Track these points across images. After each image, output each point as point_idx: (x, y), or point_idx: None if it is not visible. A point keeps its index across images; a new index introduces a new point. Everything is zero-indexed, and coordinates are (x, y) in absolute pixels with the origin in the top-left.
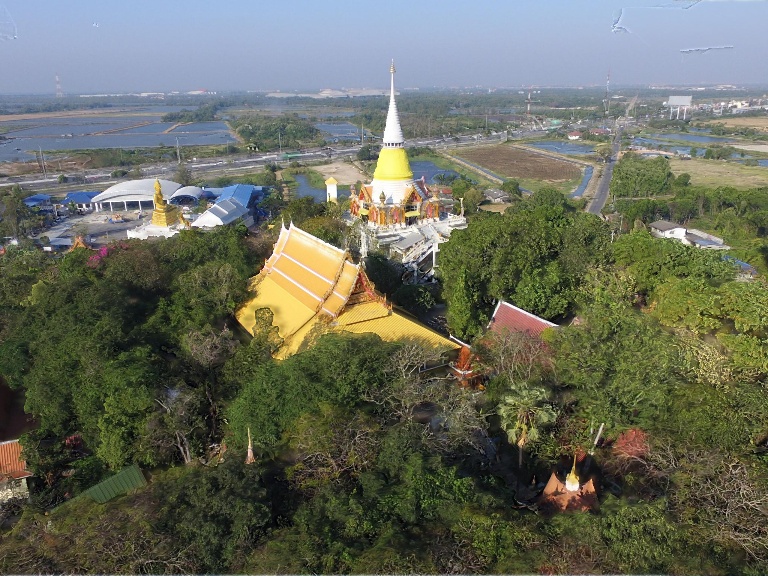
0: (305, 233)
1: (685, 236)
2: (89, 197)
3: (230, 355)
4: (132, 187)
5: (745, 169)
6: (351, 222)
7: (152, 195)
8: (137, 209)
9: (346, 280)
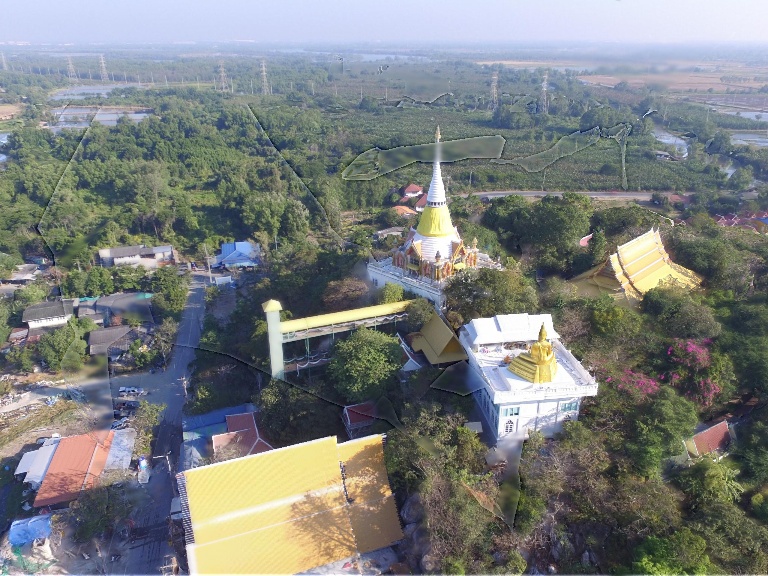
0: None
1: None
2: None
3: (732, 275)
4: None
5: None
6: None
7: None
8: None
9: None
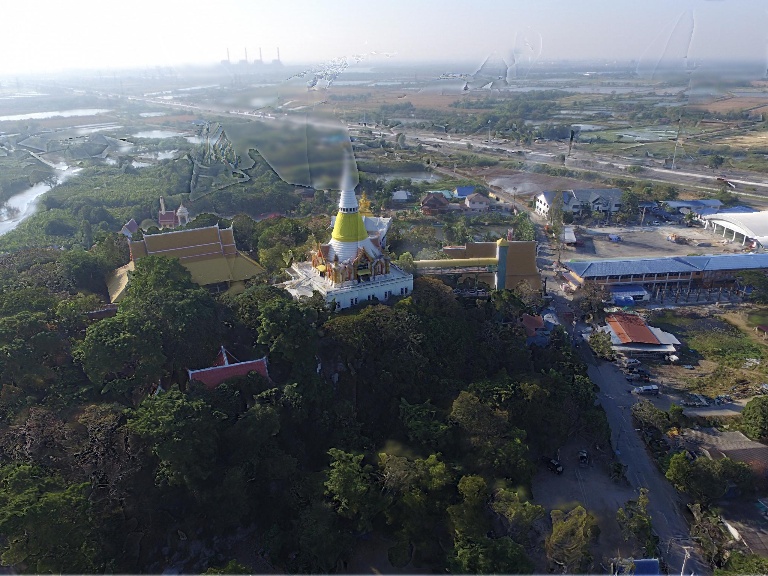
0: None
1: None
2: (715, 213)
3: None
4: (745, 215)
5: None
6: None
7: None
8: None
9: None
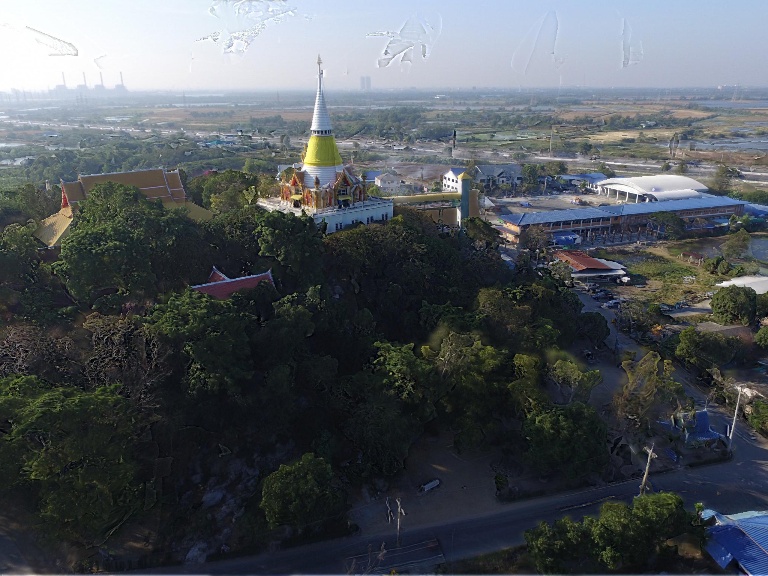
0: None
1: None
2: None
3: None
4: (634, 178)
5: None
6: None
7: (637, 189)
8: (624, 200)
9: None
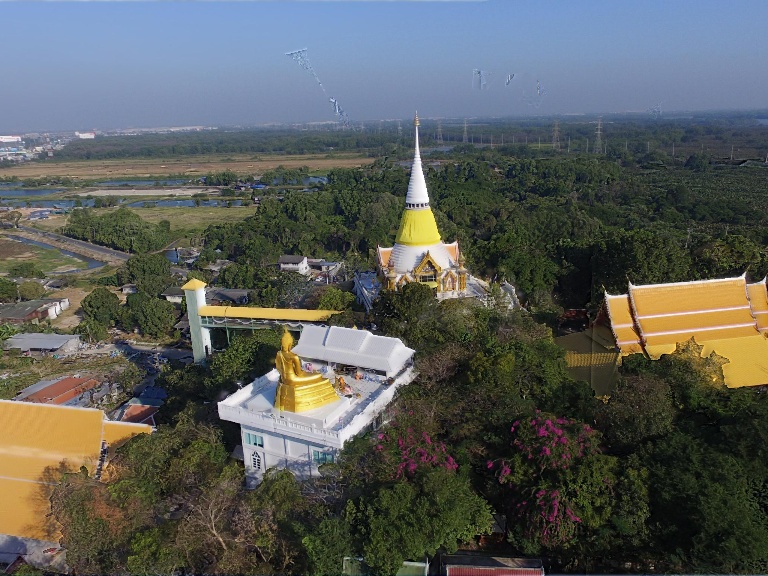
0: (666, 284)
1: (308, 263)
2: None
3: None
4: None
5: (160, 210)
6: (439, 299)
7: None
8: None
9: (757, 298)
